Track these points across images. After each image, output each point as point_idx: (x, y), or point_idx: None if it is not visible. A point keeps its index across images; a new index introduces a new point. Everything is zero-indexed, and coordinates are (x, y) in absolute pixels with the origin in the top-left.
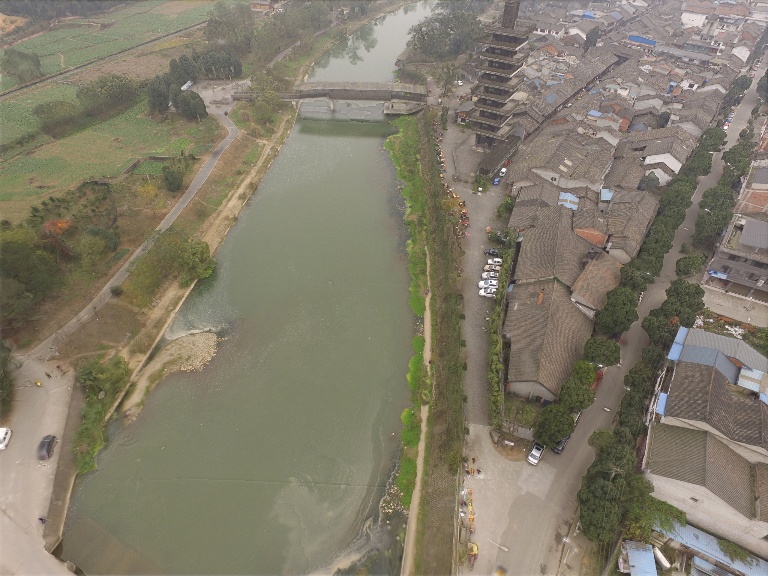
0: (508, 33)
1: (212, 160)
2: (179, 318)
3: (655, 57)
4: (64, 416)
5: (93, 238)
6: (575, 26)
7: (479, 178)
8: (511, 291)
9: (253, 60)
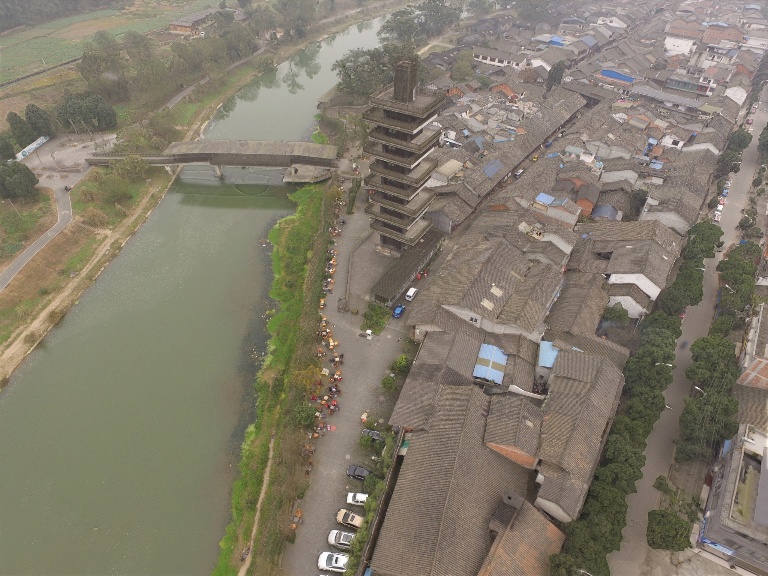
0: (400, 109)
1: (9, 273)
2: None
3: (631, 101)
4: None
5: None
6: (538, 57)
7: None
8: None
9: (146, 101)
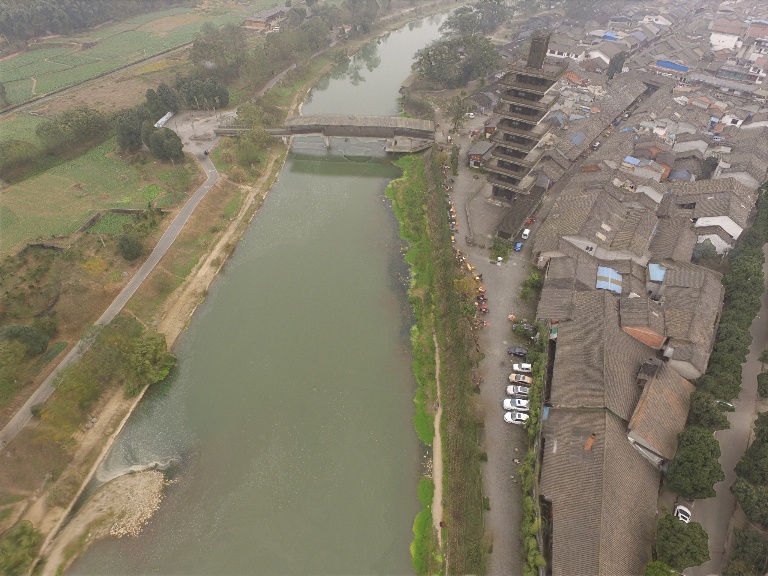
0: (535, 74)
1: (184, 214)
2: (118, 446)
3: (690, 87)
4: None
5: (10, 343)
6: (597, 49)
7: (498, 244)
8: (546, 419)
9: (243, 85)
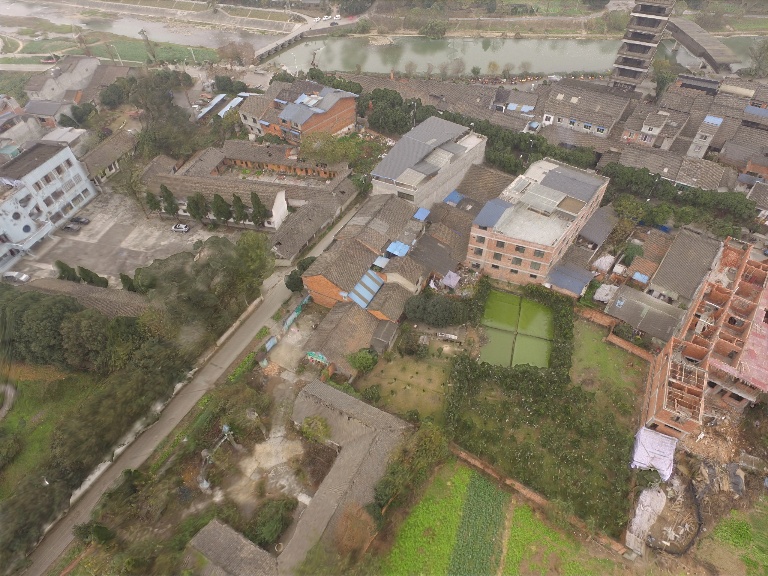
0: None
1: (536, 18)
2: None
3: None
4: (346, 24)
5: None
6: None
7: None
8: None
9: None
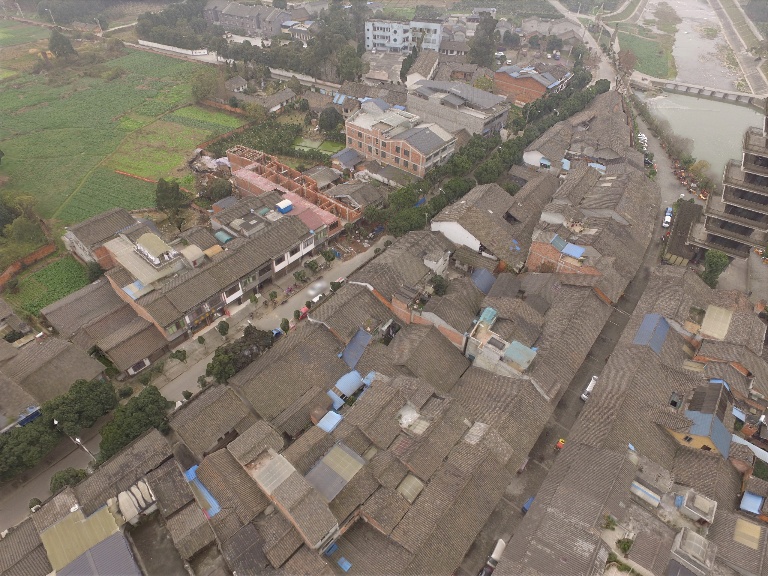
0: None
1: None
2: None
3: None
4: None
5: None
6: None
7: None
8: None
9: None
